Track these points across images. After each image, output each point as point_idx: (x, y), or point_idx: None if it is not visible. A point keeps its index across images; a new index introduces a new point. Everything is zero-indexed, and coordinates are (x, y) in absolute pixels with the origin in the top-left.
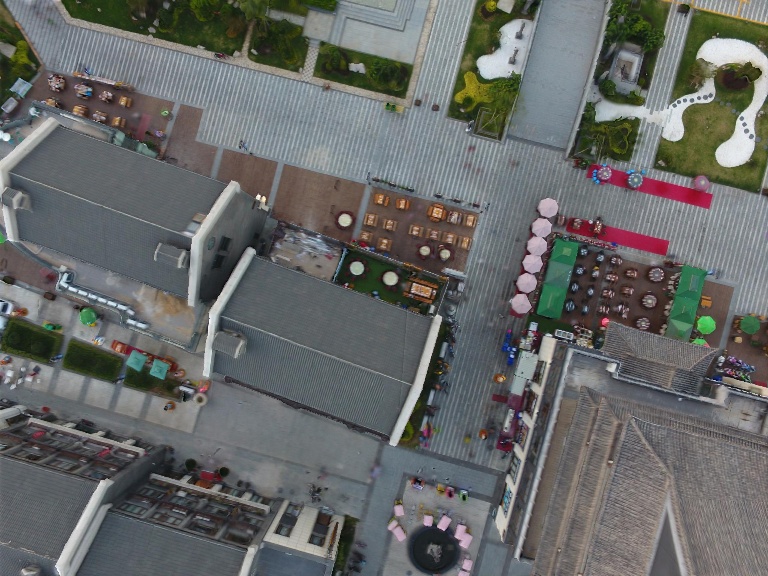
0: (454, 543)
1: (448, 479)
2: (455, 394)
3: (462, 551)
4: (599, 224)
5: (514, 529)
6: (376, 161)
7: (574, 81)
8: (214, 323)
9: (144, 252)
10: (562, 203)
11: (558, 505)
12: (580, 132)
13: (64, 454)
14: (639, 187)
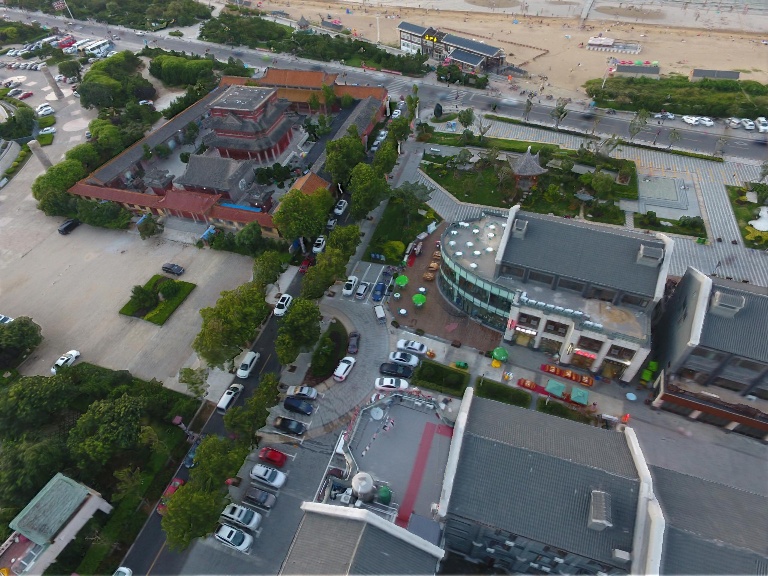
0: None
1: None
2: None
3: None
4: None
5: None
6: (705, 268)
7: None
8: (709, 287)
9: (615, 260)
10: None
11: None
12: None
13: None
14: None
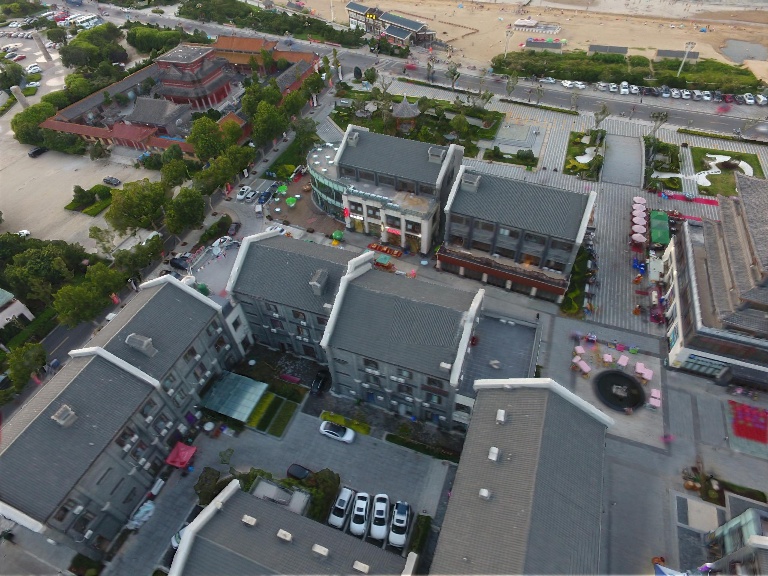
0: (636, 386)
1: (616, 340)
2: (605, 289)
3: (646, 394)
4: (676, 211)
5: (689, 325)
6: None
7: (634, 162)
8: (462, 171)
9: (415, 160)
10: (647, 205)
11: (716, 272)
12: (646, 177)
13: None
14: (694, 199)
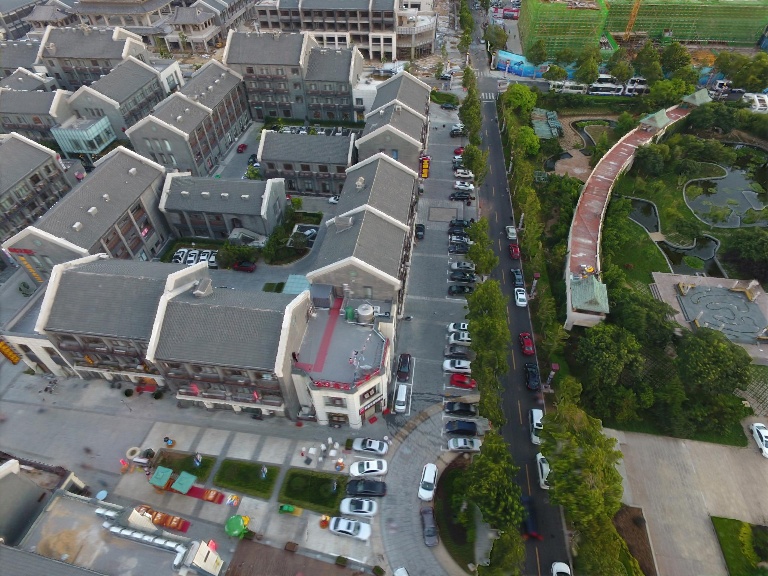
0: None
1: None
2: None
3: None
4: None
5: None
6: None
7: None
8: None
9: None
10: None
11: None
12: None
13: (216, 380)
14: None
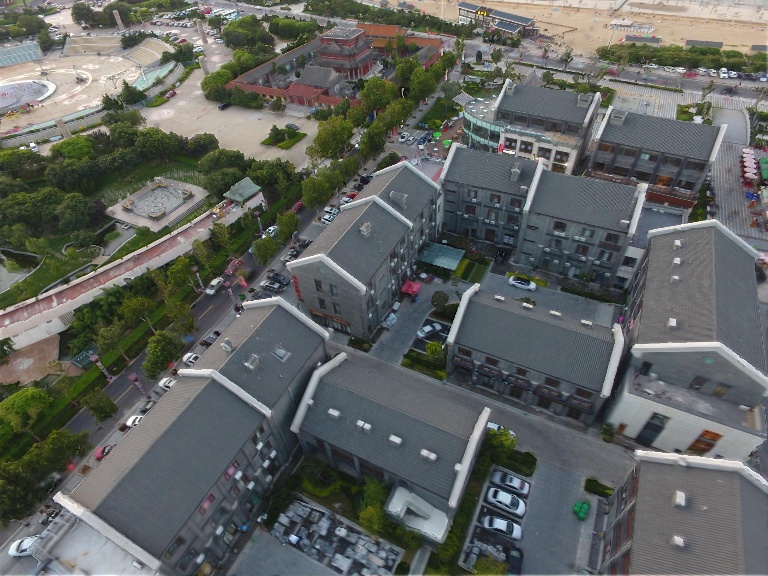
0: (758, 270)
1: None
2: (724, 210)
3: (767, 274)
4: None
5: None
6: None
7: (739, 126)
8: (611, 110)
9: (565, 105)
10: None
11: None
12: (752, 137)
13: None
14: None
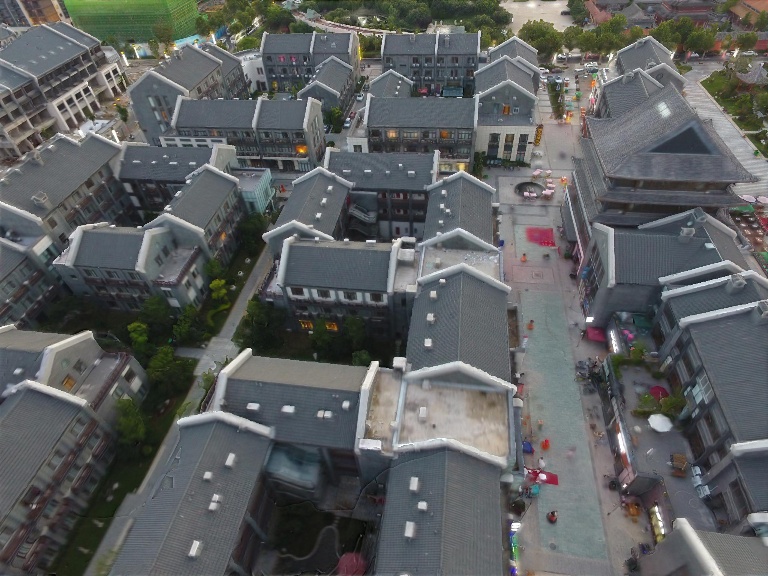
0: None
1: None
2: None
3: None
4: None
5: None
6: None
7: None
8: None
9: None
10: None
11: None
12: None
13: None
14: None
